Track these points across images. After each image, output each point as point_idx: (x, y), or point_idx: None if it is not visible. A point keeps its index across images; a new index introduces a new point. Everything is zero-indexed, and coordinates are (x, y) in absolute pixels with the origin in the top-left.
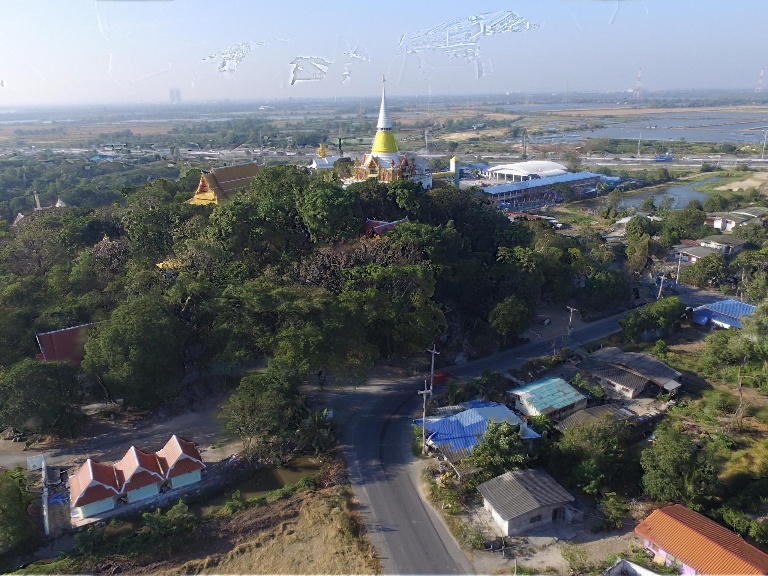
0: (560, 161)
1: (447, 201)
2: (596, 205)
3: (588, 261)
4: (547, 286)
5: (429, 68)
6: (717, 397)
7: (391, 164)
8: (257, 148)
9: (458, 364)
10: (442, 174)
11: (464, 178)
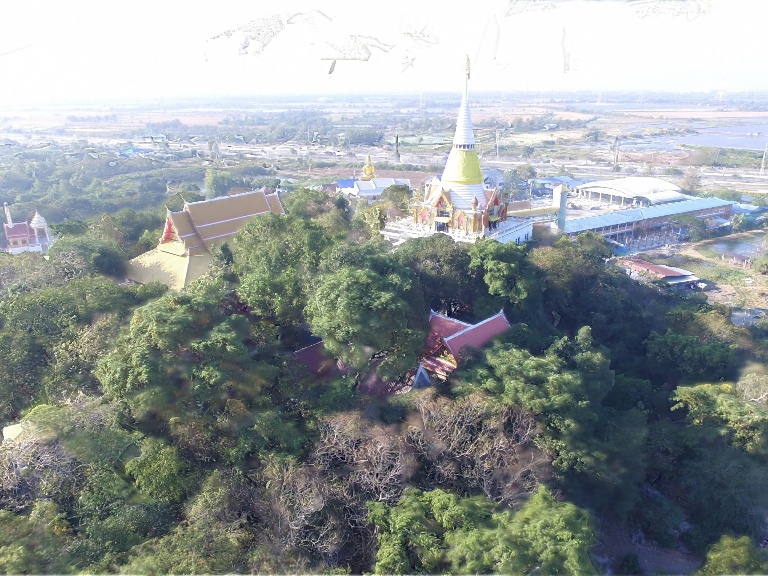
0: (671, 179)
1: (566, 274)
2: (737, 247)
3: None
4: None
5: (505, 59)
6: None
7: (472, 204)
8: (304, 146)
9: None
10: (541, 210)
11: (546, 195)
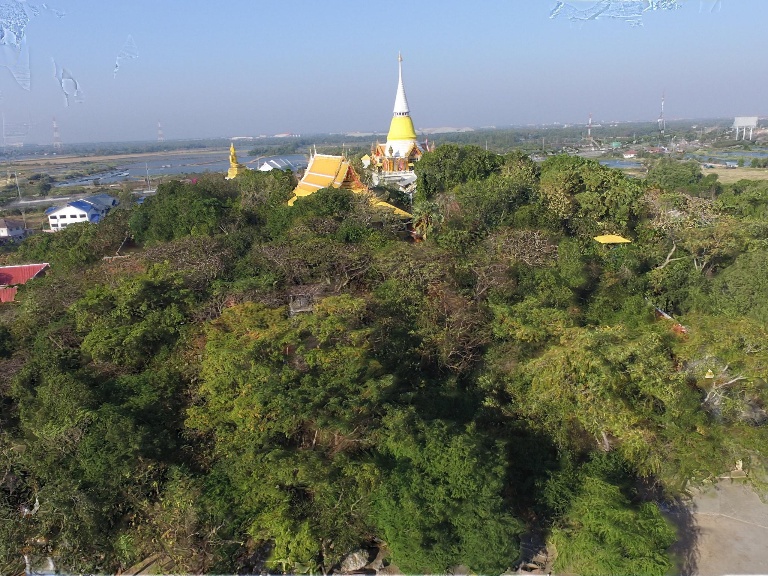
0: None
1: None
2: None
3: None
4: None
5: None
6: None
7: None
8: None
9: None
10: None
11: None
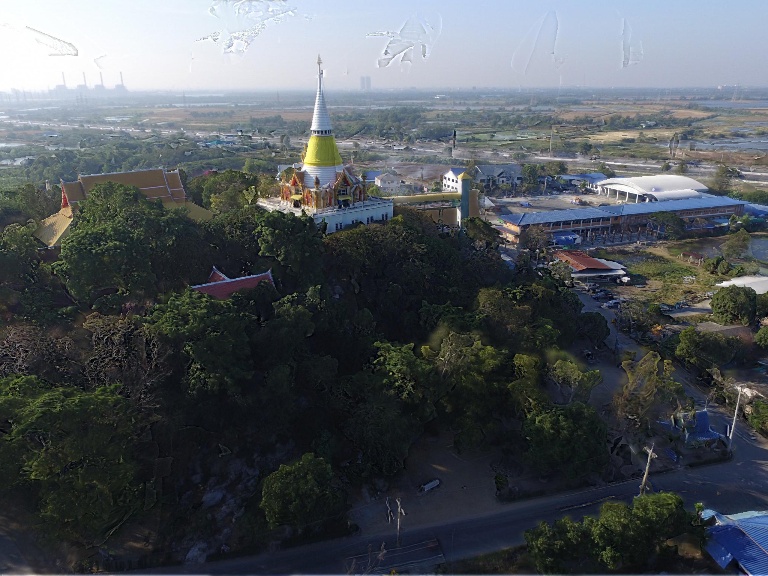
0: (699, 178)
1: (365, 247)
2: (717, 248)
3: (543, 382)
4: (453, 418)
5: (563, 54)
6: None
7: (314, 183)
8: (372, 140)
9: (186, 564)
10: (440, 196)
11: (566, 191)
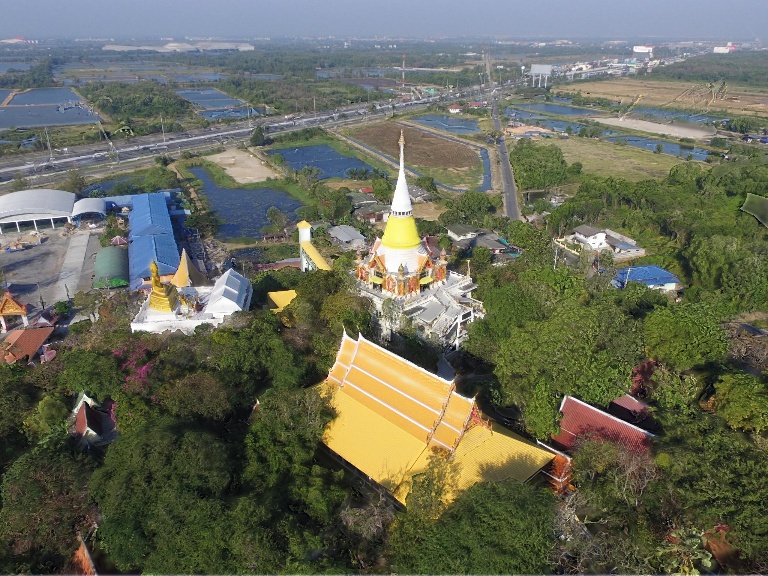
0: (57, 186)
1: None
2: (234, 230)
3: None
4: None
5: None
6: (763, 326)
7: (445, 256)
8: None
9: None
10: None
11: None
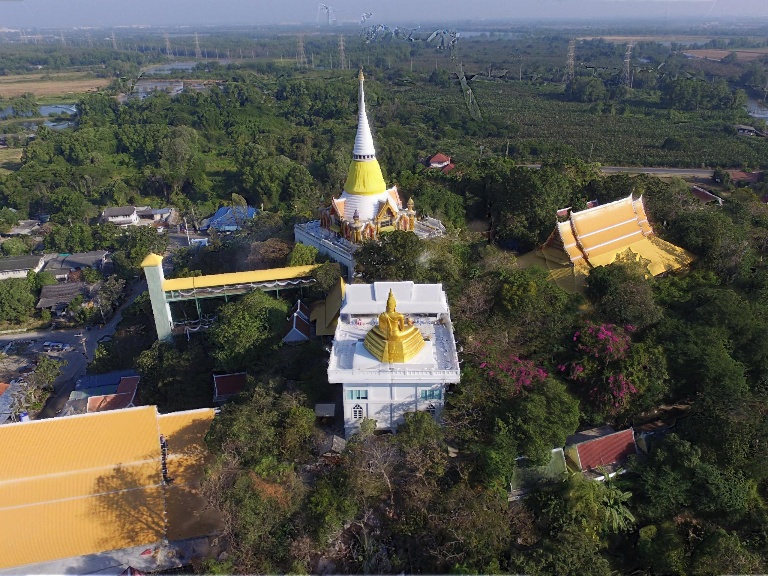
0: None
1: None
2: None
3: None
4: None
5: None
6: None
7: None
8: None
9: None
10: None
11: None
